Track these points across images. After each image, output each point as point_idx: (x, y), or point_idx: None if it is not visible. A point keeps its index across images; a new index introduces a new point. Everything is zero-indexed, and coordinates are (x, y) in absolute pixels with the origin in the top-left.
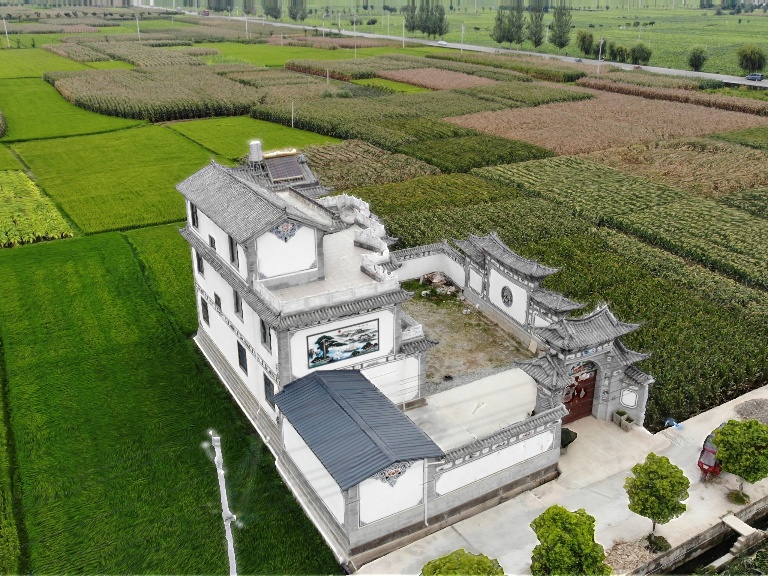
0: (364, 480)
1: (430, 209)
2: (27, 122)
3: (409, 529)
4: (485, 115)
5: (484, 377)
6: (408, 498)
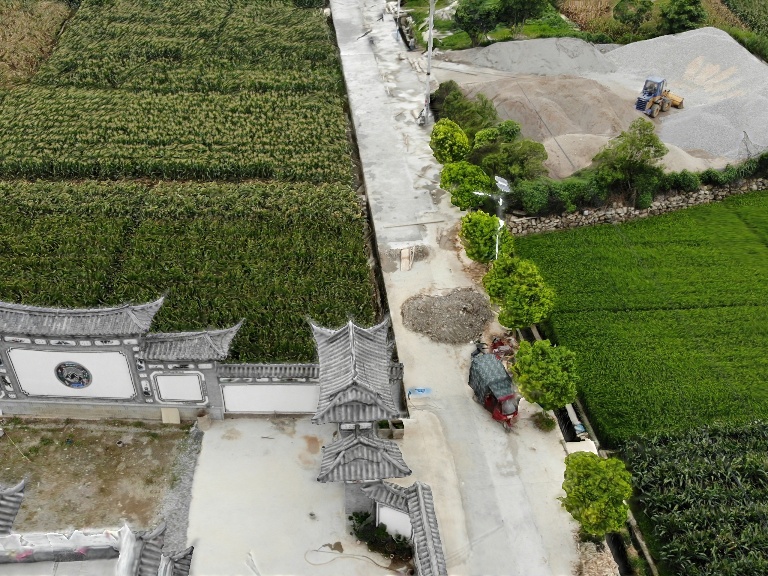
0: None
1: None
2: None
3: None
4: None
5: (187, 515)
6: None
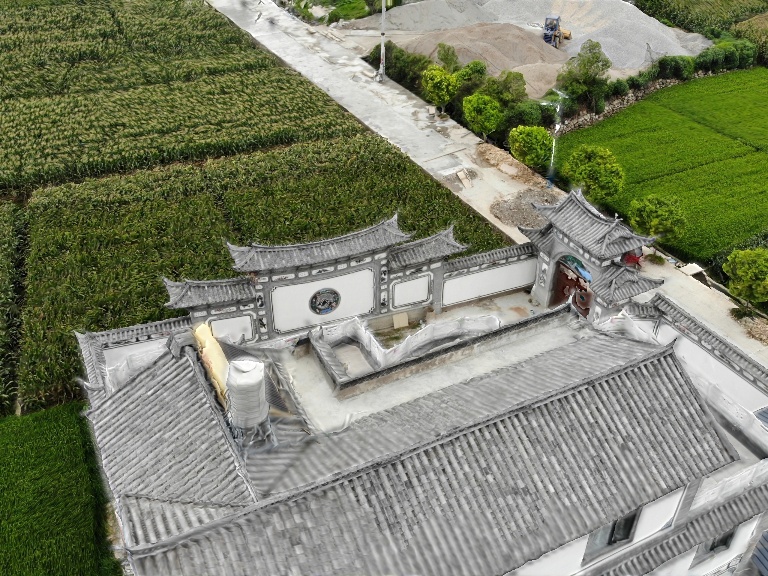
0: None
1: None
2: None
3: None
4: None
5: None
6: None
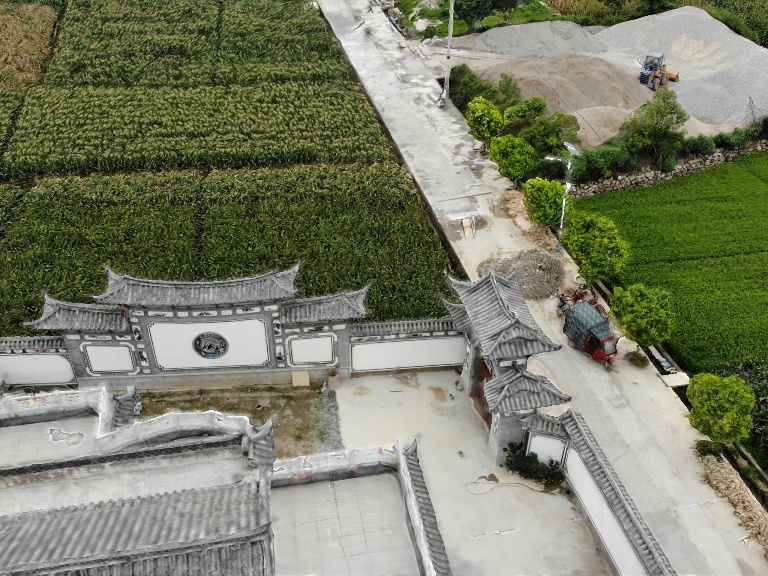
0: None
1: None
2: None
3: None
4: None
5: None
6: None
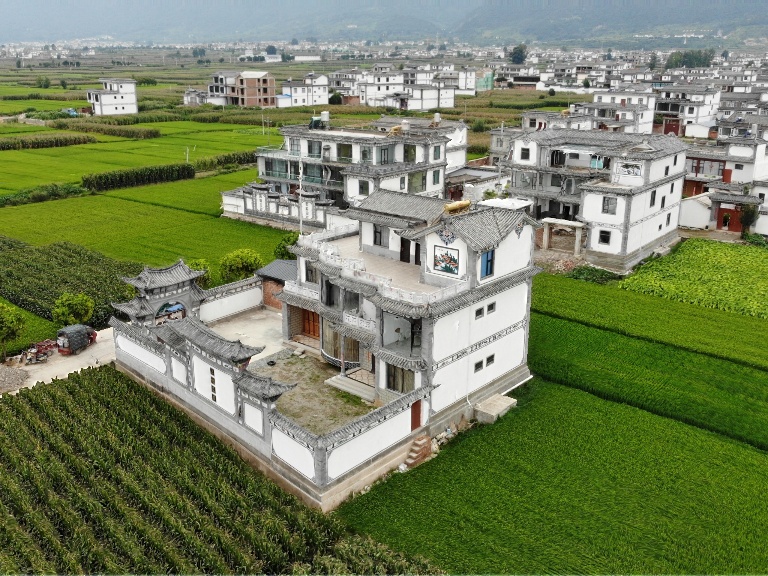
0: None
1: None
2: None
3: None
4: None
5: None
6: None
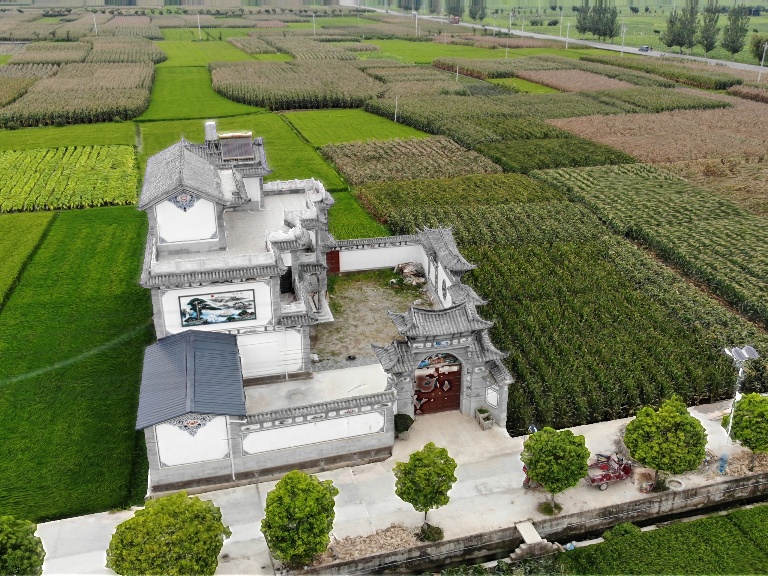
0: (160, 424)
1: (461, 205)
2: (166, 105)
3: (215, 479)
4: (592, 119)
5: None
6: (212, 450)
